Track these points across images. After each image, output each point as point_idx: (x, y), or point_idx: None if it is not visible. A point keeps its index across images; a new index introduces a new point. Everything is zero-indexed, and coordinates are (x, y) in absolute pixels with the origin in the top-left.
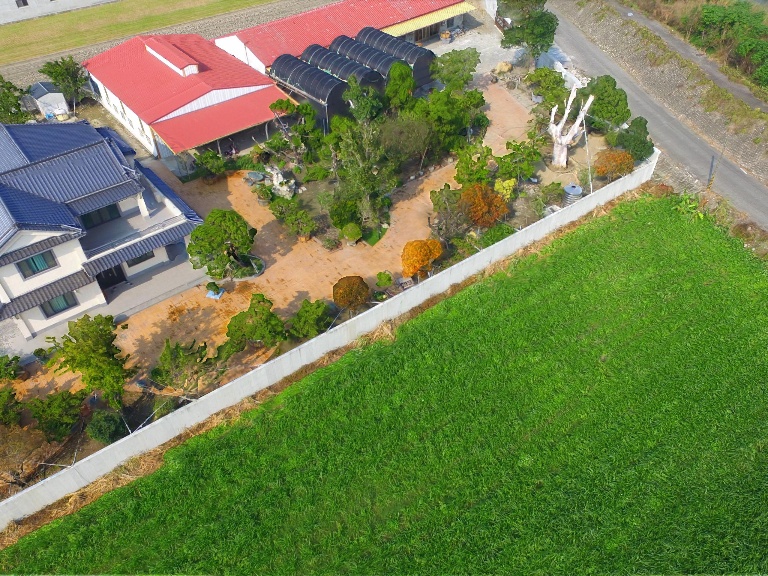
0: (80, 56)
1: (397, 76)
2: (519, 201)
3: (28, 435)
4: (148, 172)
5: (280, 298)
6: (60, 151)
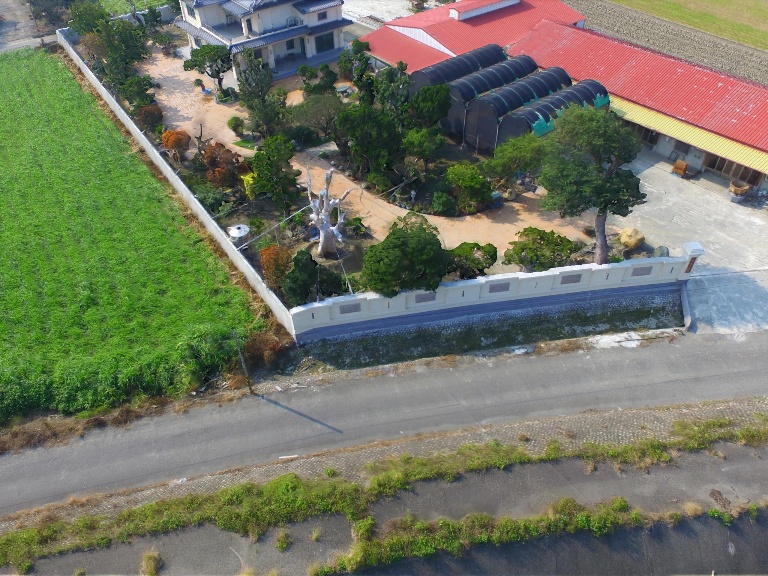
0: (588, 5)
1: (420, 90)
2: (275, 223)
3: (101, 47)
4: (302, 30)
5: (189, 111)
6: None
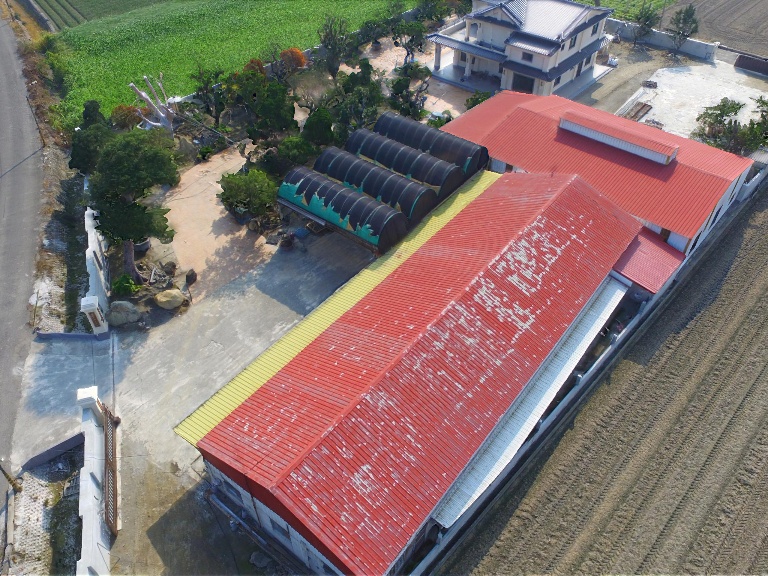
0: None
1: None
2: None
3: None
4: (497, 56)
5: (376, 62)
6: (532, 9)
